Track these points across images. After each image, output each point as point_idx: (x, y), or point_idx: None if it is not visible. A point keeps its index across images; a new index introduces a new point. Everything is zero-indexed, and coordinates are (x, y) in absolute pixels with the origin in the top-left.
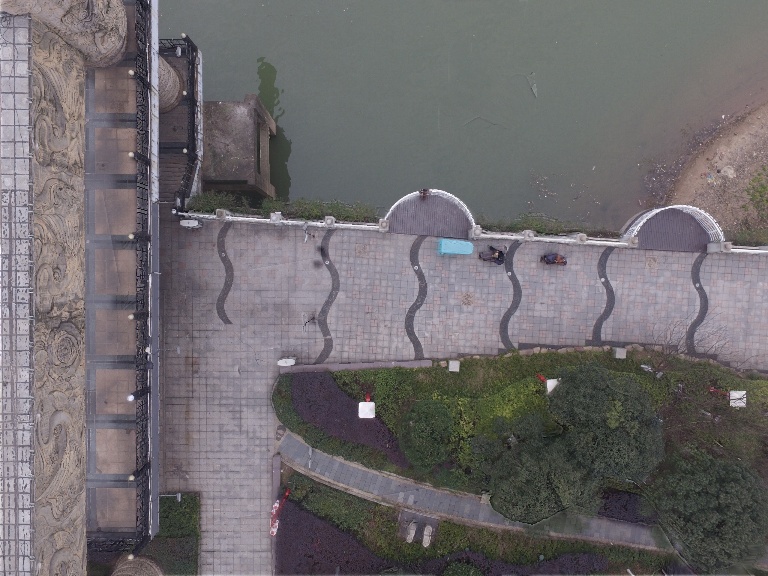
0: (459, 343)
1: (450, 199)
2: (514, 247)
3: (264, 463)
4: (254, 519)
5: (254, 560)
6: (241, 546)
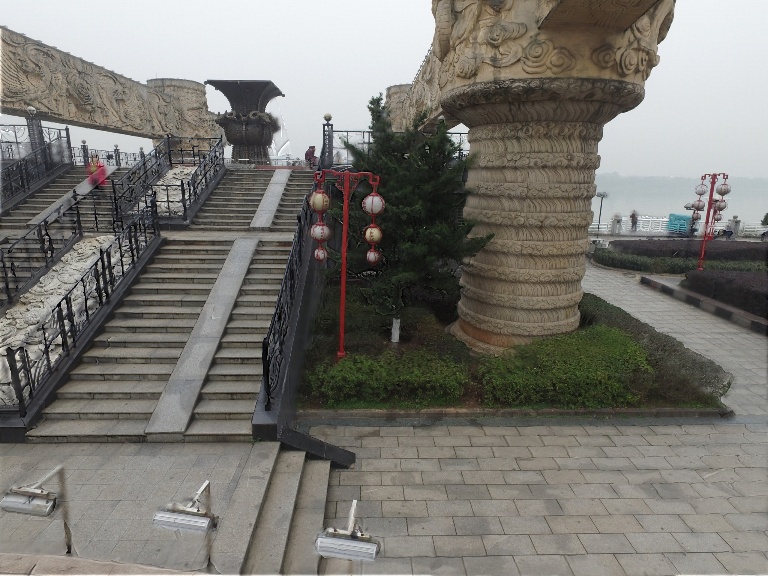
0: None
1: (653, 231)
2: (731, 239)
3: (633, 286)
4: (675, 312)
5: (737, 341)
6: (687, 329)
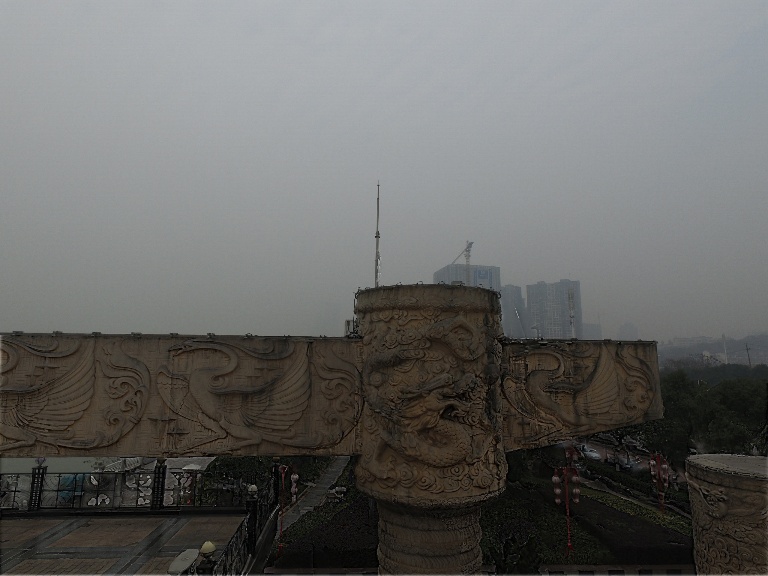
0: (167, 501)
1: None
2: None
3: None
4: None
5: None
6: None
